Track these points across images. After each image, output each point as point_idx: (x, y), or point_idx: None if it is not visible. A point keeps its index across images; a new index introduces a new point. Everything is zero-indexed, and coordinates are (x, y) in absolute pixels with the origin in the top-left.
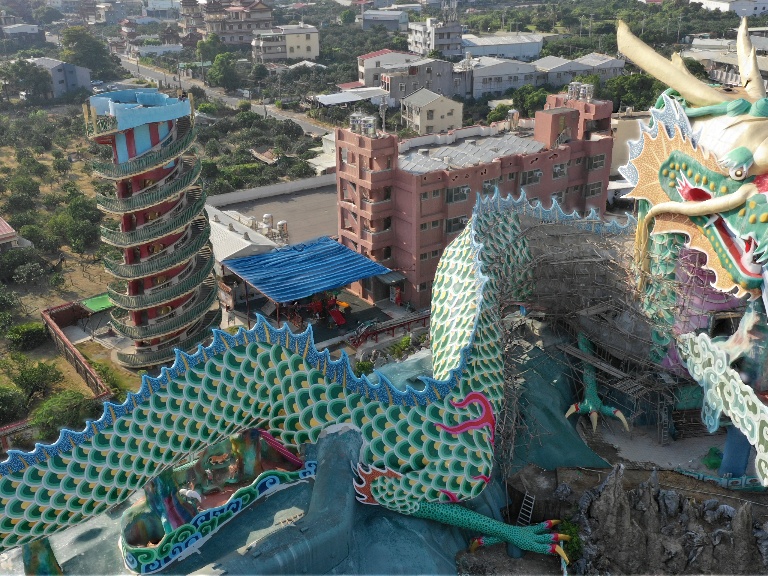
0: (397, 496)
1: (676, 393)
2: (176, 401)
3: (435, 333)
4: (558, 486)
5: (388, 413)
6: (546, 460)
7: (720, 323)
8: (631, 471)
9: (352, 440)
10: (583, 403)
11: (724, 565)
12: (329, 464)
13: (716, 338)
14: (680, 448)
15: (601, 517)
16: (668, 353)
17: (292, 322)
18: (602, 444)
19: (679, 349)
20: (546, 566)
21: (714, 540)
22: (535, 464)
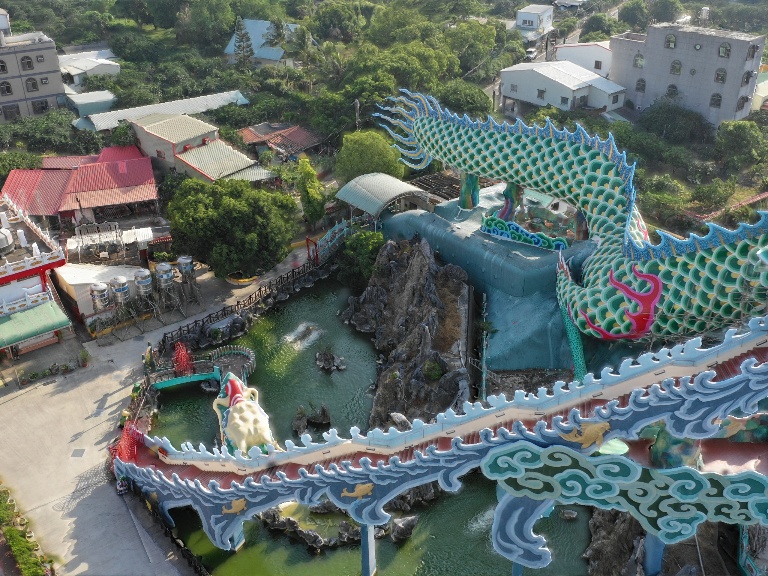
0: None
1: None
2: (527, 146)
3: None
4: None
5: None
6: None
7: None
8: None
9: (589, 248)
10: None
11: None
12: None
13: None
14: None
15: None
16: None
17: None
18: None
19: None
20: None
21: None
22: None
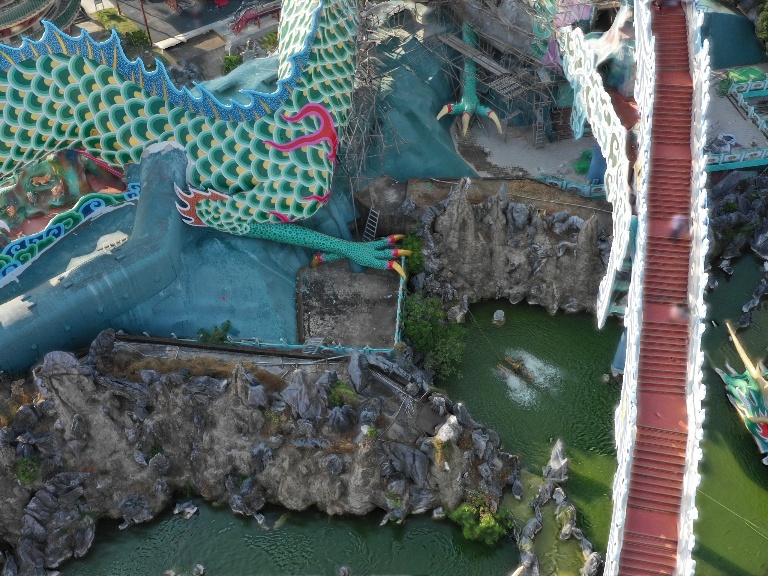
0: (224, 219)
1: (555, 92)
2: None
3: (281, 31)
4: (405, 200)
5: (214, 130)
6: (403, 170)
7: (603, 14)
8: (487, 181)
9: (176, 160)
10: (459, 103)
11: (566, 275)
12: (150, 187)
13: (589, 35)
14: (554, 151)
15: (444, 232)
16: (548, 47)
17: (168, 4)
18: (473, 148)
19: (557, 44)
20: (386, 280)
21: (558, 252)
22: (388, 175)
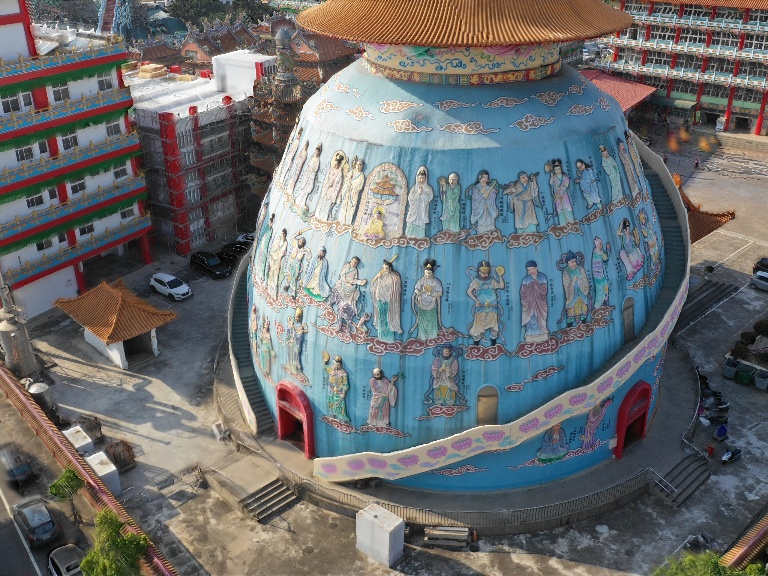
0: None
1: None
2: None
3: None
4: None
5: None
6: None
7: None
8: None
9: None
10: None
11: None
12: None
13: None
14: None
15: None
16: None
17: None
18: None
19: None
20: None
21: None
22: None
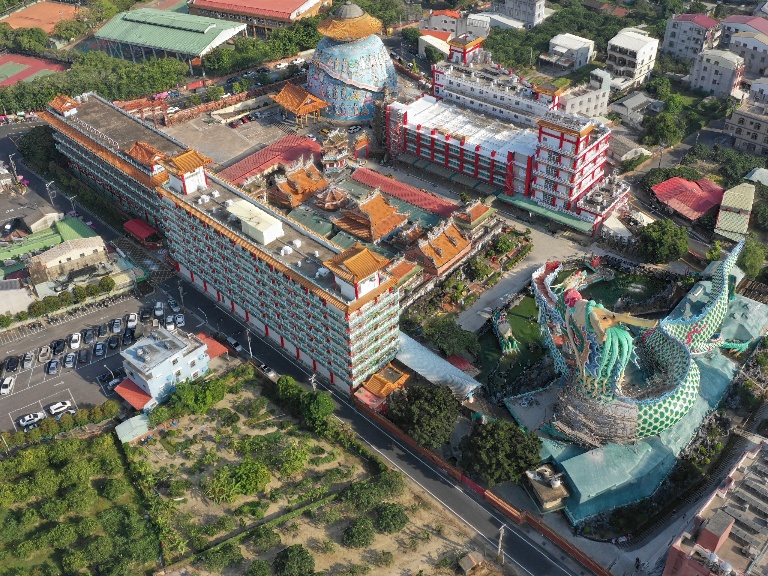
0: None
1: None
2: None
3: None
4: None
5: None
6: None
7: None
8: None
9: None
10: None
11: None
12: None
13: None
14: None
15: None
16: None
17: None
18: None
19: None
20: None
21: None
22: None
